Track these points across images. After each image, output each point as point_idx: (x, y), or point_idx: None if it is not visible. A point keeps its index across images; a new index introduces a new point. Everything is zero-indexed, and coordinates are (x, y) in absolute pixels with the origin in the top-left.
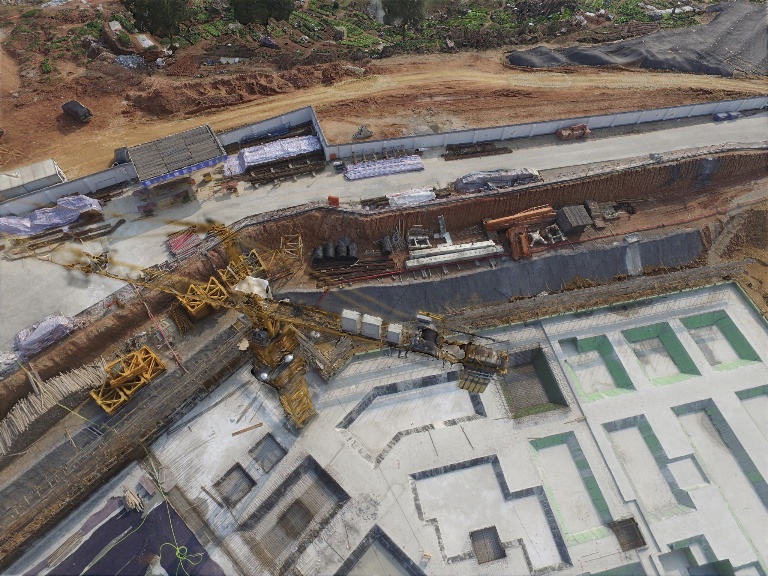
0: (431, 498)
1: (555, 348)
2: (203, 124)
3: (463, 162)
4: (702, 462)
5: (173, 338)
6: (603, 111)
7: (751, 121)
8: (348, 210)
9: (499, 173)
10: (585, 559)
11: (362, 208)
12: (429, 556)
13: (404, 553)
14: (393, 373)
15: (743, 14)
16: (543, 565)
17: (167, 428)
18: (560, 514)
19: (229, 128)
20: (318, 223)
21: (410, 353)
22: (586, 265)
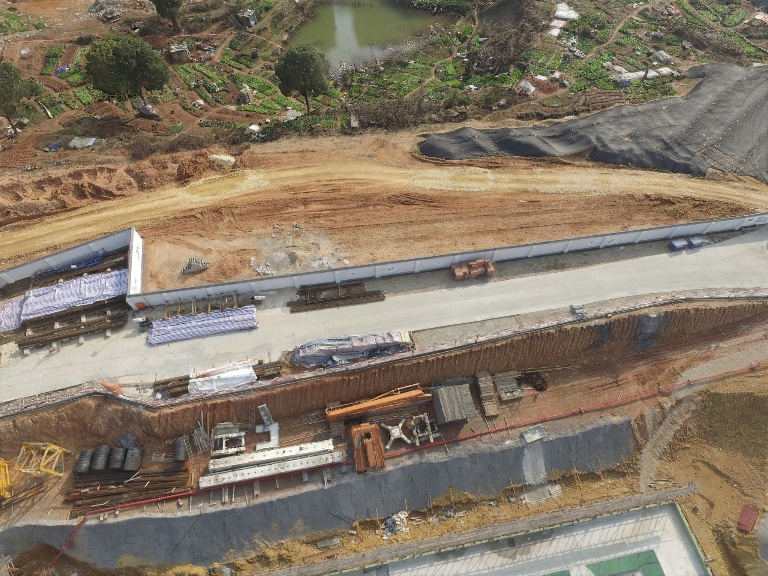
0: None
1: None
2: (2, 244)
3: (314, 315)
4: None
5: None
6: (523, 231)
7: (720, 251)
8: (131, 399)
9: (350, 342)
10: None
11: (152, 395)
12: None
13: None
14: None
15: (732, 82)
16: None
17: None
18: None
19: (33, 251)
20: (91, 415)
21: None
22: (464, 473)
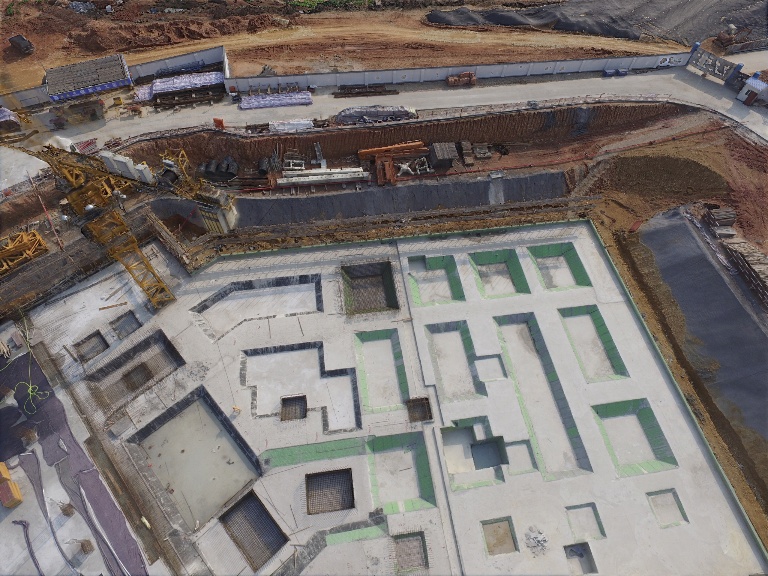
0: (257, 370)
1: (403, 263)
2: (129, 60)
3: (350, 100)
4: (507, 361)
5: (60, 227)
6: None
7: (639, 78)
8: (232, 132)
9: (376, 108)
10: (374, 425)
11: (245, 132)
12: (238, 410)
13: (219, 407)
14: (251, 272)
15: None
16: (338, 428)
17: (45, 299)
18: (366, 392)
19: None
20: (205, 143)
21: (271, 258)
22: (449, 196)
